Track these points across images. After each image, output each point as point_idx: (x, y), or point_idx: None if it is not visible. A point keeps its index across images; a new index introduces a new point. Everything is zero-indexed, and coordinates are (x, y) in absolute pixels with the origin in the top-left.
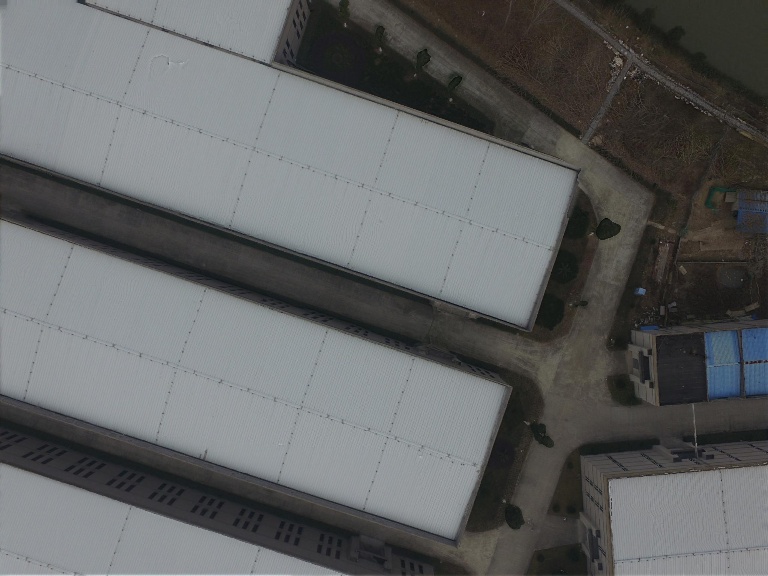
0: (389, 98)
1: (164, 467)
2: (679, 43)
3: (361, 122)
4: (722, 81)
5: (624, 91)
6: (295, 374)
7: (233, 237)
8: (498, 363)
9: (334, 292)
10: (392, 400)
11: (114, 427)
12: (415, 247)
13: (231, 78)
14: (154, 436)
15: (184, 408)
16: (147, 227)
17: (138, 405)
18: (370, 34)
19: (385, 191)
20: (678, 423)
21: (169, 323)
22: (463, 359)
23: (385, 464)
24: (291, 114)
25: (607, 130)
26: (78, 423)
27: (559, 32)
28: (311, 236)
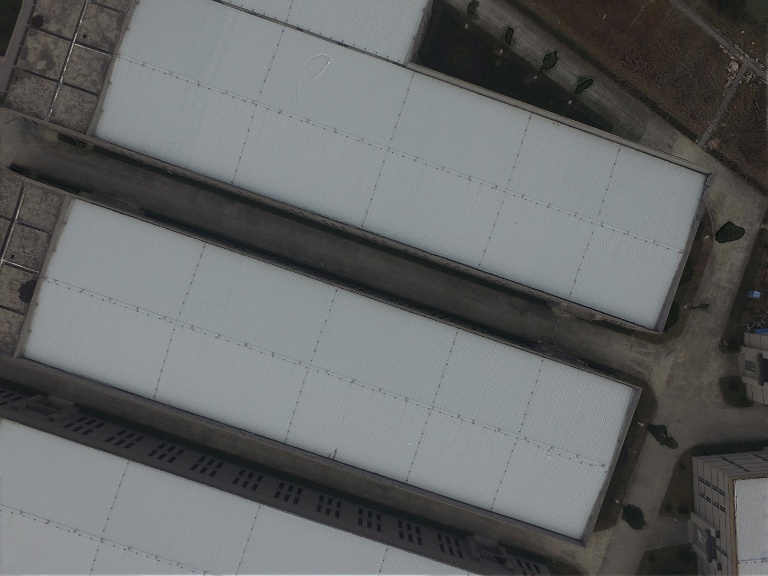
0: None
1: (280, 466)
2: None
3: (494, 124)
4: None
5: (741, 95)
6: (426, 374)
7: (352, 237)
8: (612, 364)
9: (451, 293)
10: (522, 401)
11: (244, 426)
12: (549, 249)
13: (366, 78)
14: (284, 435)
15: (315, 407)
16: (266, 226)
17: (269, 404)
18: (490, 35)
19: (518, 193)
20: None
21: (301, 322)
22: None
23: (514, 464)
24: (425, 115)
25: (723, 134)
26: (194, 422)
27: (678, 36)
28: (445, 237)
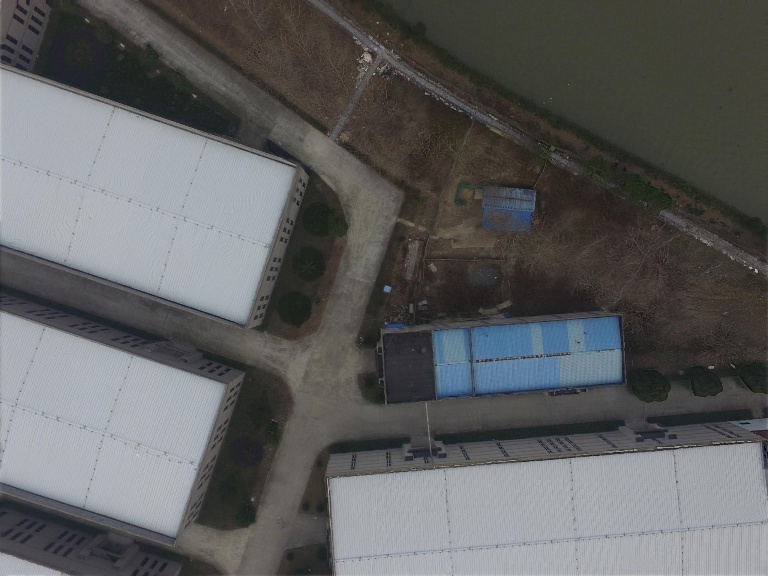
0: (129, 94)
1: None
2: (427, 39)
3: (75, 118)
4: (473, 77)
5: (370, 87)
6: (11, 371)
7: None
8: (246, 361)
9: (80, 289)
10: (109, 398)
11: None
12: (125, 244)
13: None
14: None
15: None
16: None
17: None
18: (113, 30)
19: (98, 188)
20: (430, 422)
21: None
22: (210, 357)
23: (103, 462)
24: (3, 110)
25: (354, 126)
26: None
27: (303, 28)
28: (22, 233)
